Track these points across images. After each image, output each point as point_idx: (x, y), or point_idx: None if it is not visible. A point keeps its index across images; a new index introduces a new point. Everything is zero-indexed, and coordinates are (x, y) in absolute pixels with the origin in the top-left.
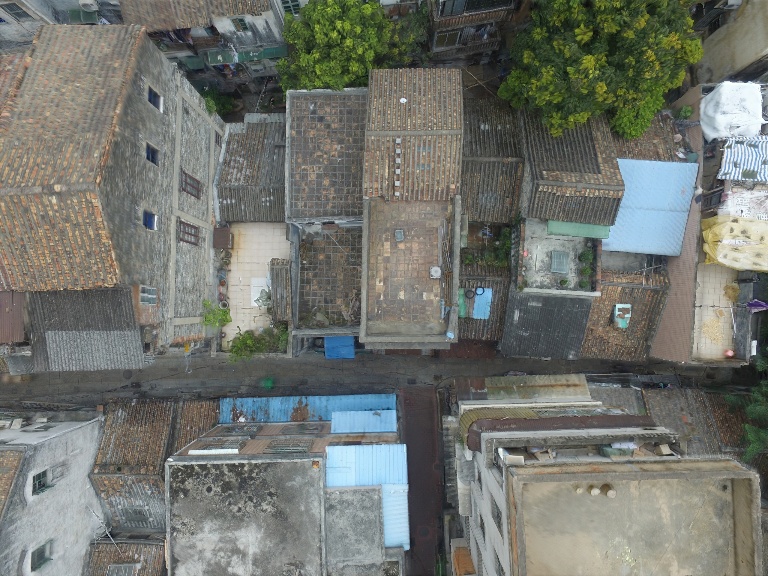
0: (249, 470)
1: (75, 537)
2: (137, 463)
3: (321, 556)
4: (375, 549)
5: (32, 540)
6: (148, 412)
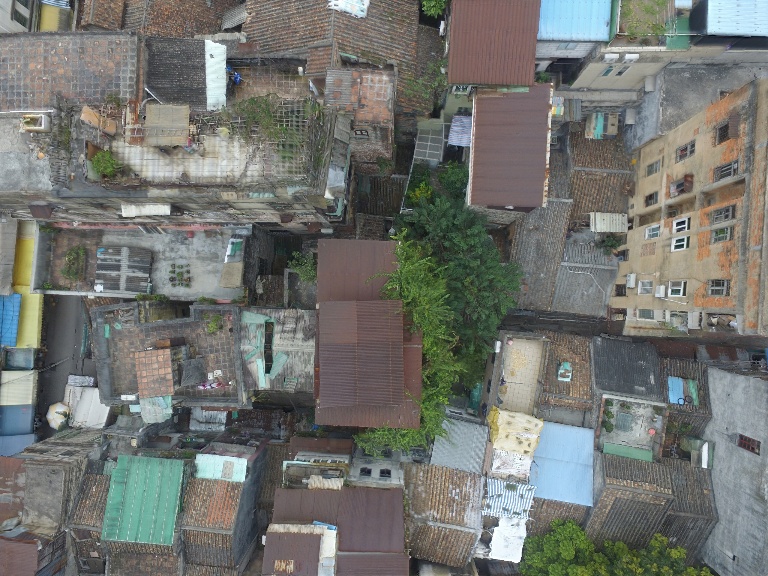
0: None
1: None
2: None
3: None
4: None
5: None
6: None
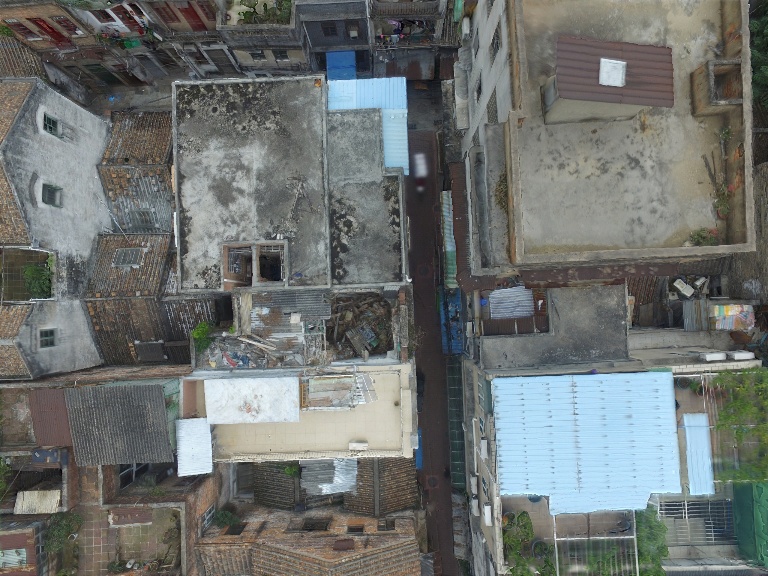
0: (253, 91)
1: (84, 213)
2: (144, 157)
3: (323, 170)
4: (375, 167)
5: (43, 172)
6: (154, 121)
